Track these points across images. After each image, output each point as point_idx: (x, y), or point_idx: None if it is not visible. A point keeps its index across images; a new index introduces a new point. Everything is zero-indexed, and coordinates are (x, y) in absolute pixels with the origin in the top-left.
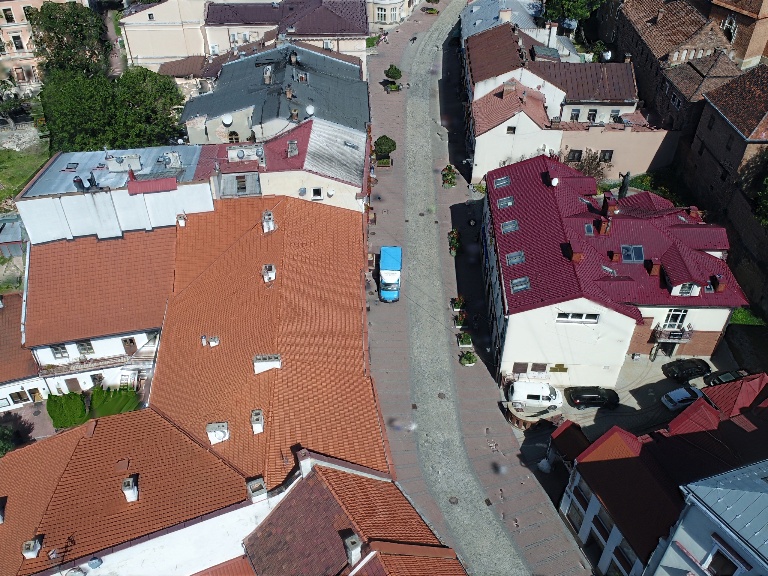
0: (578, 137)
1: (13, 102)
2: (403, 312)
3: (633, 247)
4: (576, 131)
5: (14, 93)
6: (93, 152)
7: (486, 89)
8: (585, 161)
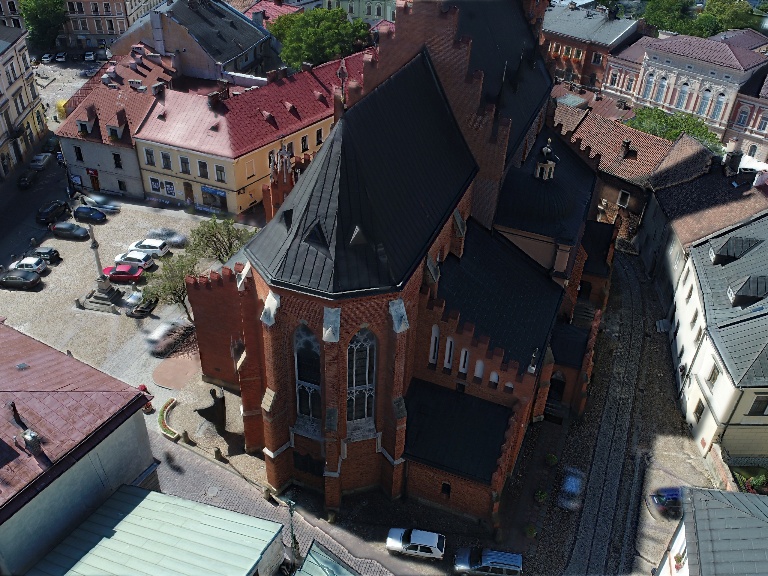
0: None
1: None
2: None
3: None
4: None
5: None
6: None
7: None
8: None
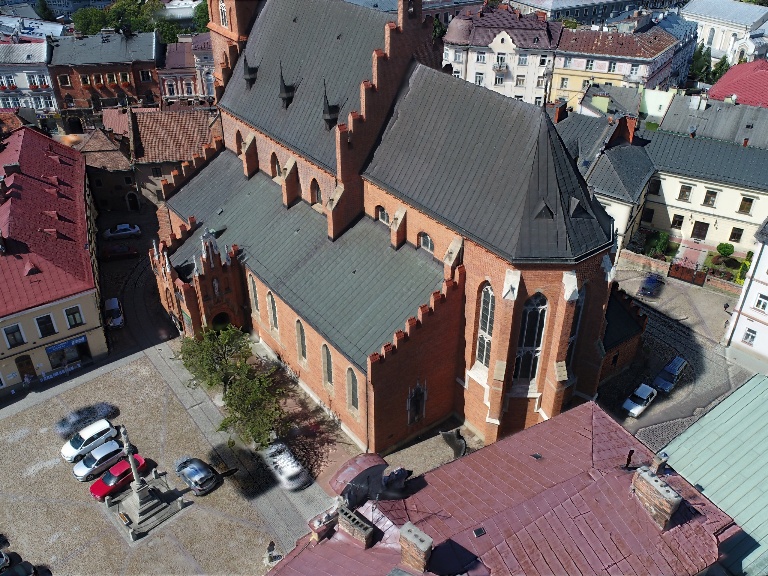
0: None
1: None
2: None
3: None
4: None
5: None
6: None
7: None
8: None
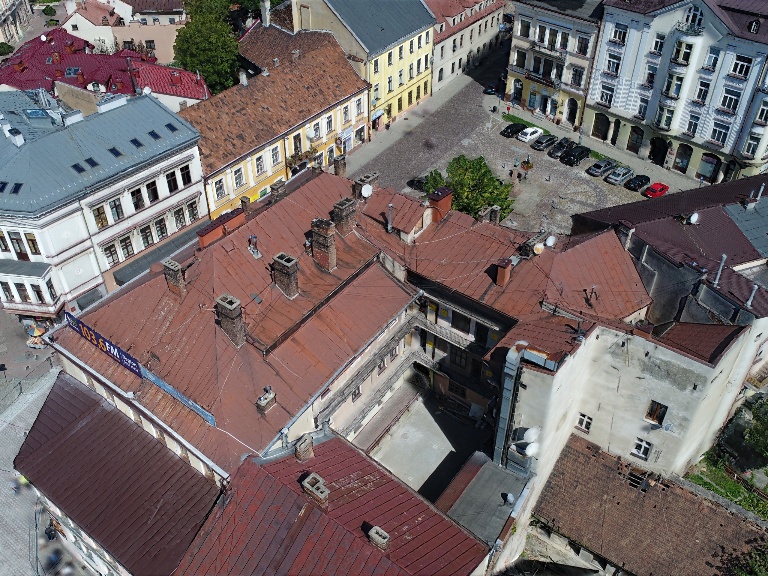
0: (125, 31)
1: None
2: None
3: (74, 69)
4: (121, 26)
5: None
6: None
7: (74, 6)
8: (135, 49)
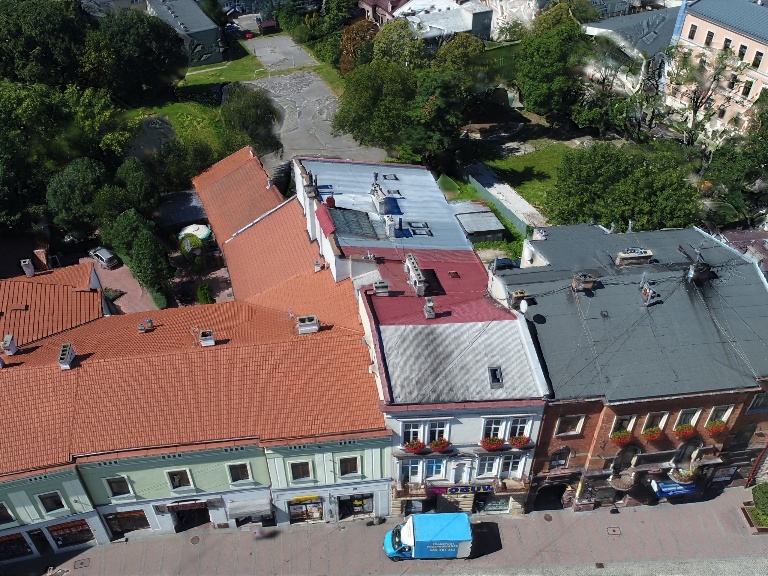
0: None
1: (698, 151)
2: (369, 568)
3: None
4: None
5: (707, 145)
6: (435, 185)
7: None
8: None
